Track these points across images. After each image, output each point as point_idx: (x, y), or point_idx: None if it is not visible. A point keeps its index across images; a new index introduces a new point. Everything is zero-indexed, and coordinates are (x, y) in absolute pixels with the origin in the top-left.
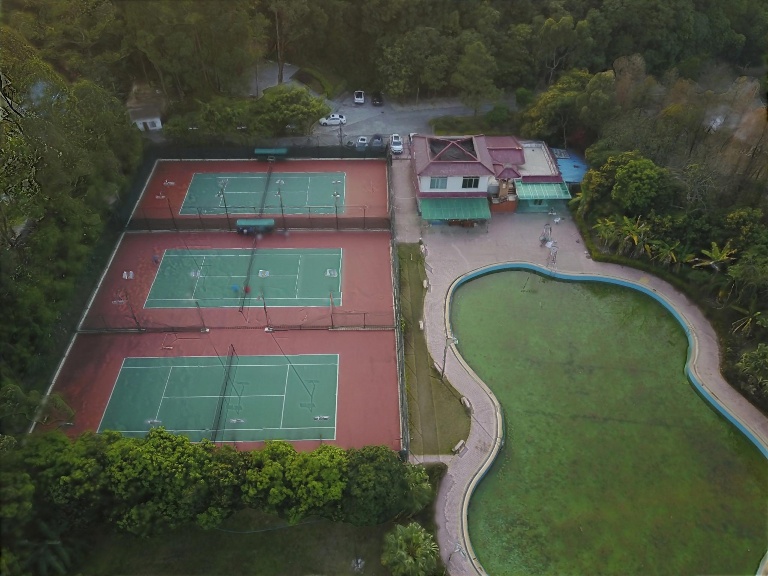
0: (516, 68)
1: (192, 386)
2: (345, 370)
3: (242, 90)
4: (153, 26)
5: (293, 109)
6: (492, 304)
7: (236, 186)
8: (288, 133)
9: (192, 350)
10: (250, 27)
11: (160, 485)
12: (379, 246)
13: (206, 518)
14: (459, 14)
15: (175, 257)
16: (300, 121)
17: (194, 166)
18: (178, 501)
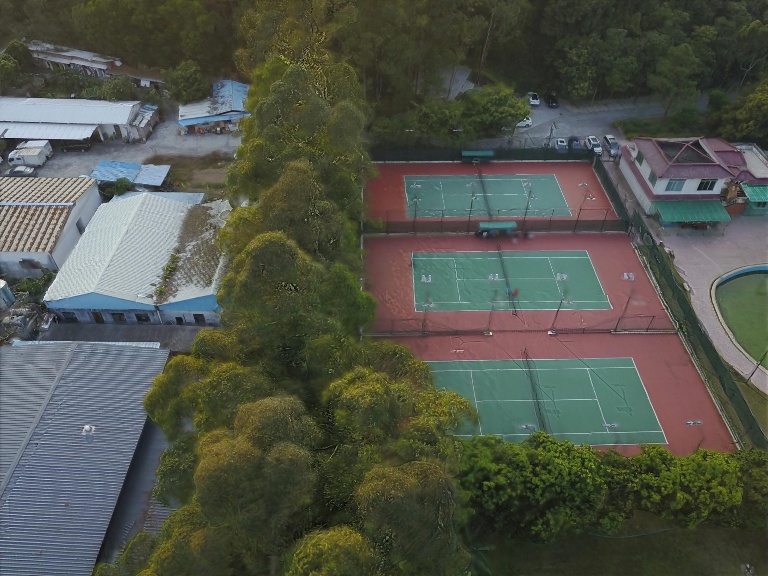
0: (700, 70)
1: (500, 390)
2: (646, 374)
3: (440, 92)
4: (379, 28)
5: (502, 111)
6: (757, 307)
7: (452, 188)
8: (481, 135)
9: (484, 354)
10: (464, 29)
11: (567, 490)
12: (622, 249)
13: (609, 523)
14: (641, 16)
15: (424, 260)
16: (509, 123)
17: (400, 168)
18: (582, 506)
